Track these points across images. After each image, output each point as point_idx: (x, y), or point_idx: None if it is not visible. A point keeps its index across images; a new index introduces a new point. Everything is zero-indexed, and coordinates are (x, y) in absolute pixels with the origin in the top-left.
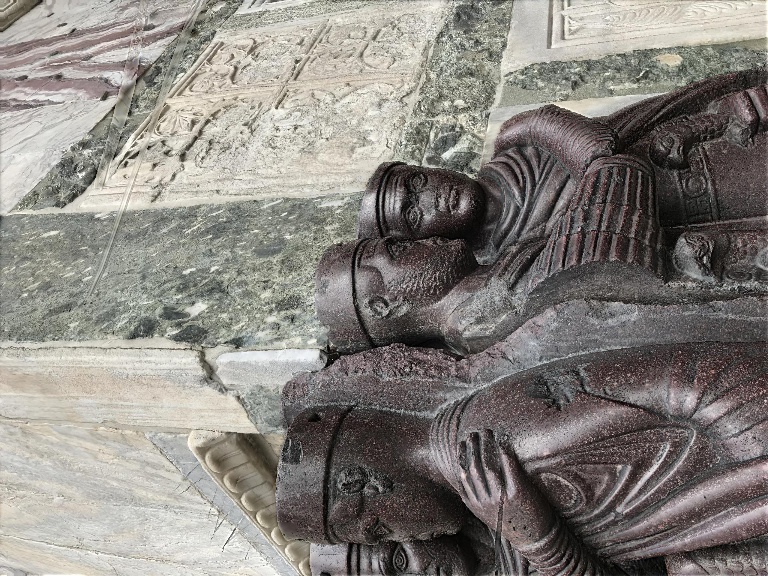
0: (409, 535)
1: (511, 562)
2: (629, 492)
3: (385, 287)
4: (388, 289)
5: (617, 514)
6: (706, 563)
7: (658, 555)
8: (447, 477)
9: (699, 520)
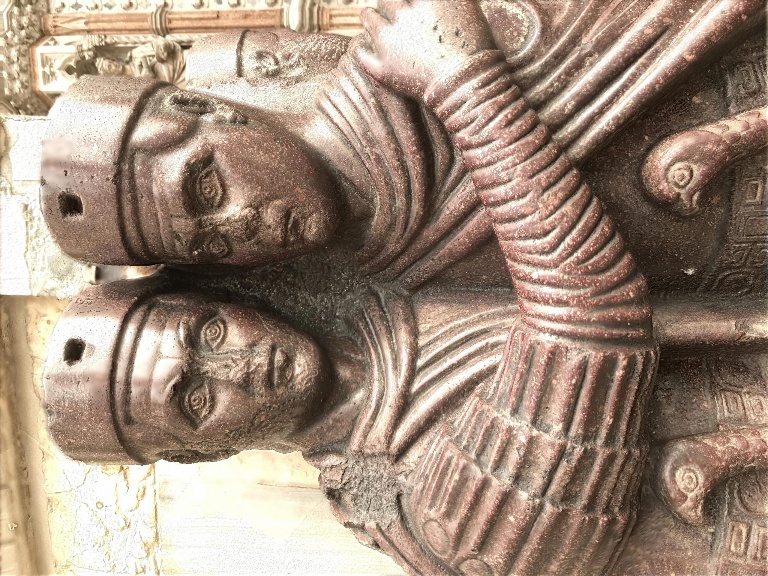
0: (253, 198)
1: (391, 357)
2: (599, 16)
3: (279, 45)
4: (282, 47)
5: (583, 46)
6: (706, 125)
7: (643, 94)
8: (334, 95)
9: (699, 5)
